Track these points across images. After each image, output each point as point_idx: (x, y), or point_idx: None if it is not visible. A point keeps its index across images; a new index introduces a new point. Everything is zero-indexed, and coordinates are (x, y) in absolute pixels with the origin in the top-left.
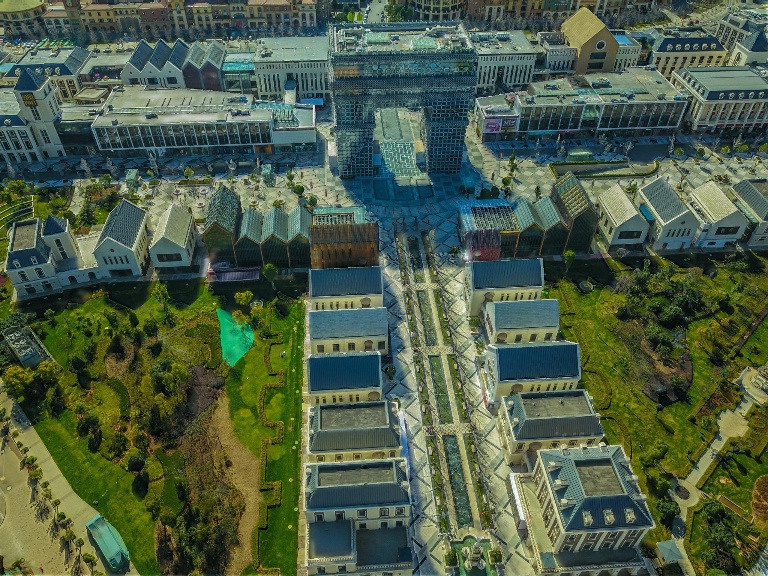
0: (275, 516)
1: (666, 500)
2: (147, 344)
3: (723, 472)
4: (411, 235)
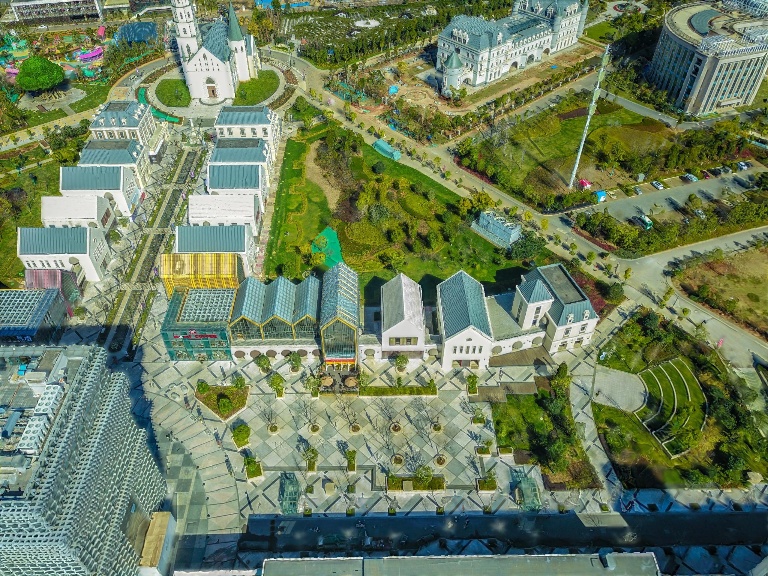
0: (297, 157)
1: (78, 145)
2: (402, 241)
3: (28, 161)
4: (114, 350)
